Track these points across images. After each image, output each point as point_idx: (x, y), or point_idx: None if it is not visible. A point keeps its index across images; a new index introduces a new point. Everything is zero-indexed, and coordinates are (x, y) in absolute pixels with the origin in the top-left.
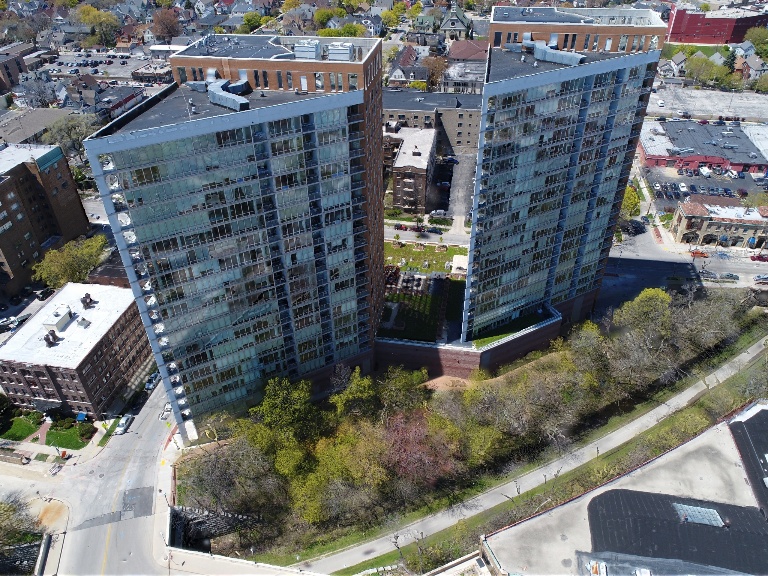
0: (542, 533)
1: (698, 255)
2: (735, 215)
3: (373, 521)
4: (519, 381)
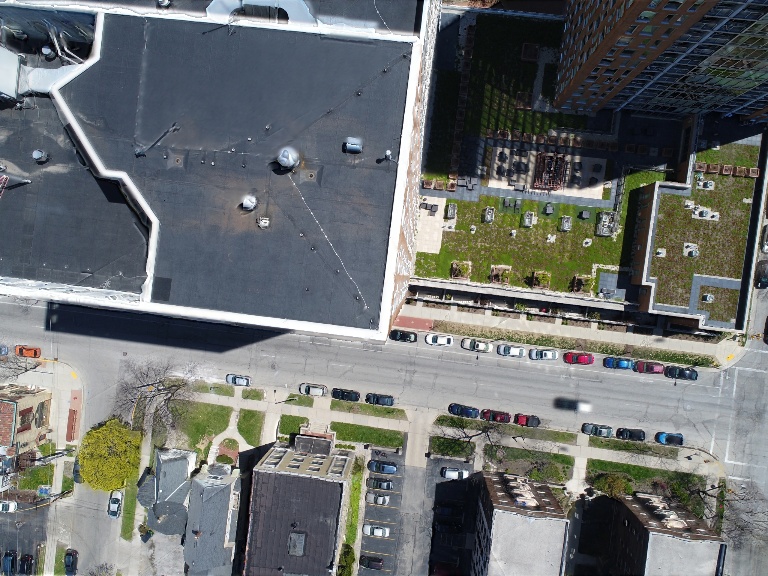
0: None
1: (30, 347)
2: None
3: None
4: None
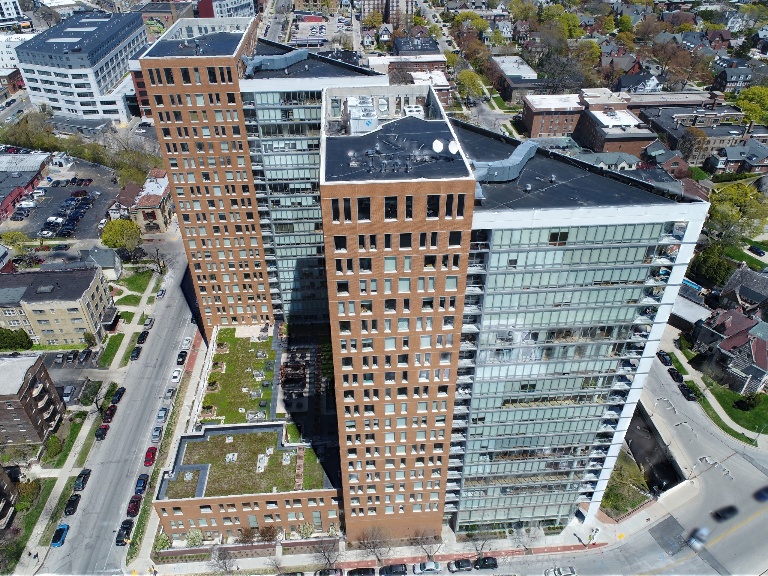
0: None
1: None
2: (158, 188)
3: None
4: None
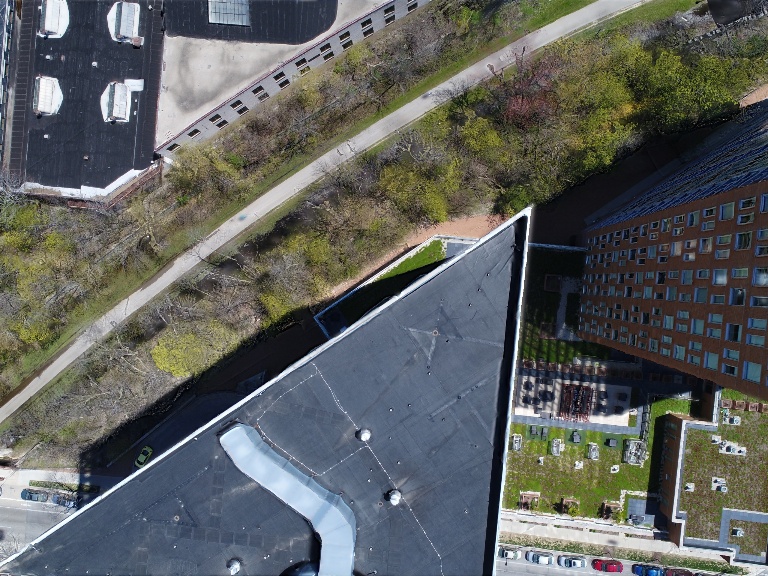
0: None
1: None
2: None
3: (548, 66)
4: (379, 251)
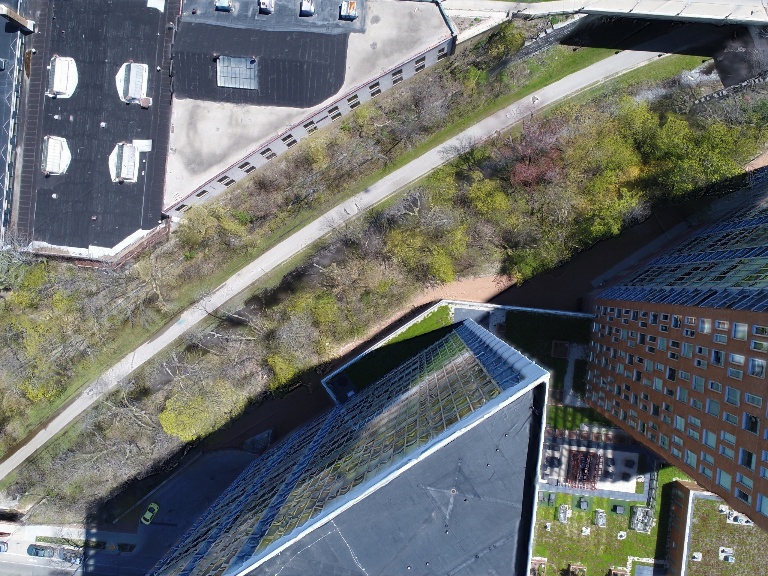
0: (395, 48)
1: None
2: None
3: (554, 124)
4: (386, 309)
